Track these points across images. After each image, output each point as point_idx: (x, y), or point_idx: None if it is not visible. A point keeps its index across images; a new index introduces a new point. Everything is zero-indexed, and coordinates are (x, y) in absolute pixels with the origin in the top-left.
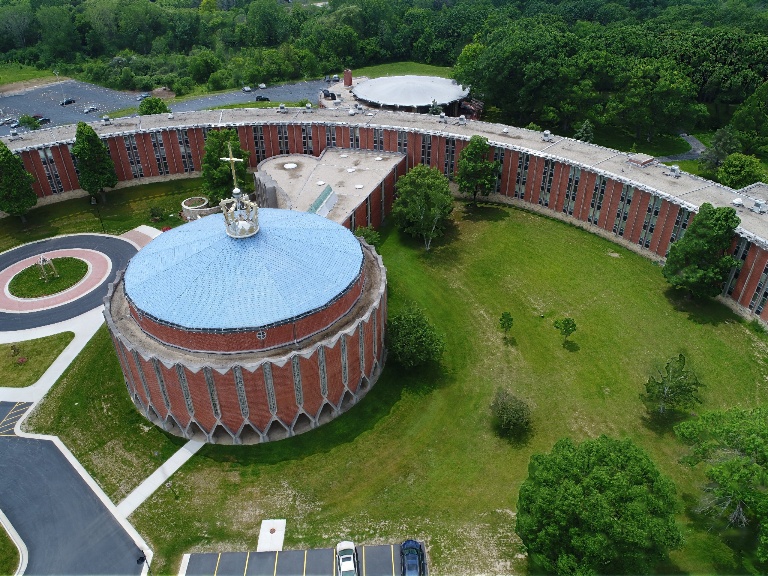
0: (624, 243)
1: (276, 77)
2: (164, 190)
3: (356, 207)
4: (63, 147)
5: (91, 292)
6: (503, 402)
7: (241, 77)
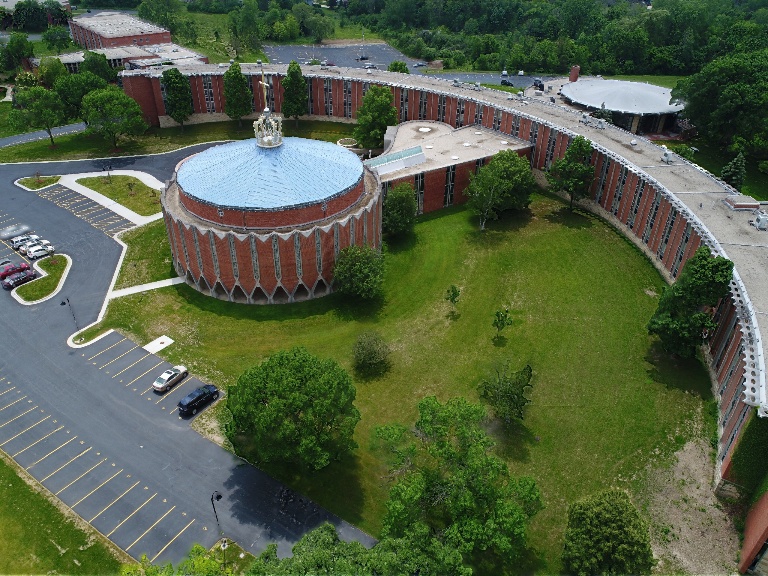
0: None
1: (542, 68)
2: (341, 129)
3: (428, 170)
4: (281, 78)
5: None
6: (361, 337)
7: (506, 62)
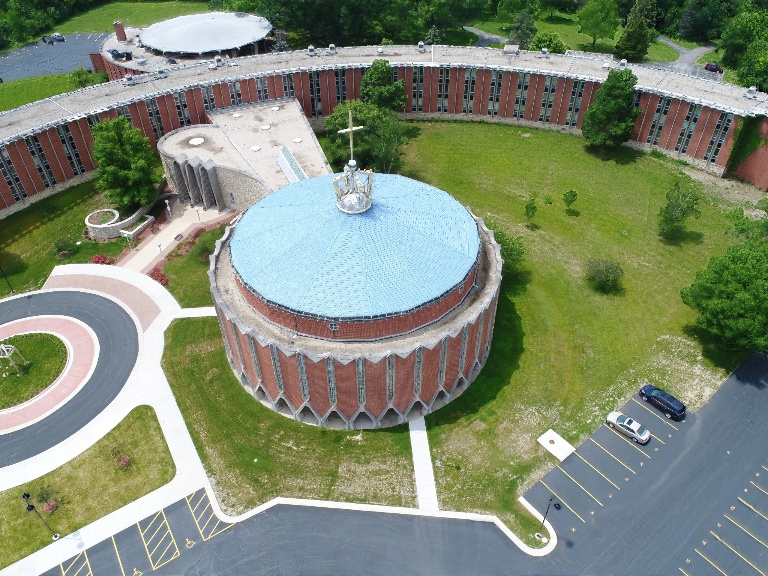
0: (525, 124)
1: None
2: (35, 218)
3: (325, 159)
4: None
5: (100, 359)
6: (605, 265)
7: None
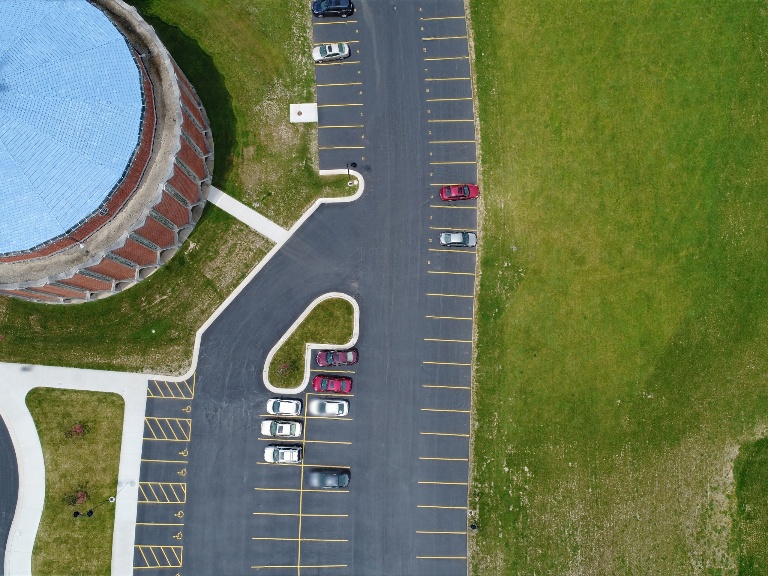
0: None
1: None
2: None
3: None
4: None
5: None
6: None
7: None
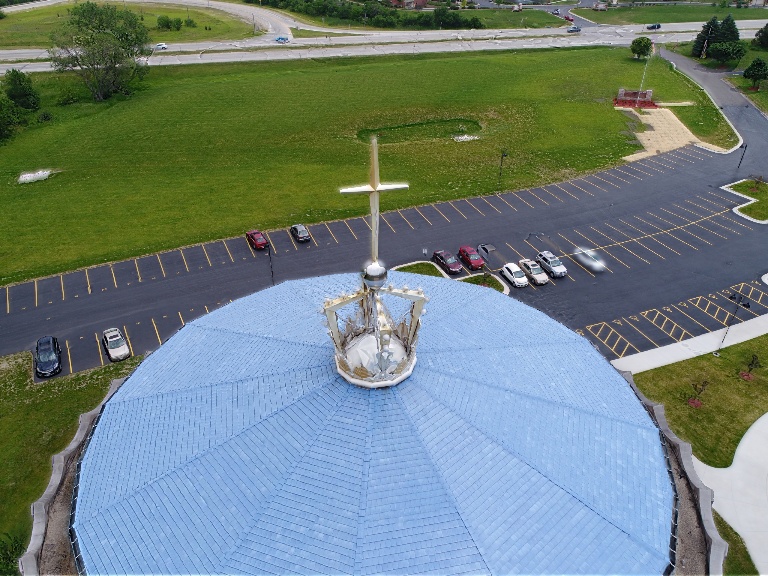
0: None
1: None
2: None
3: None
4: None
5: None
6: None
7: None
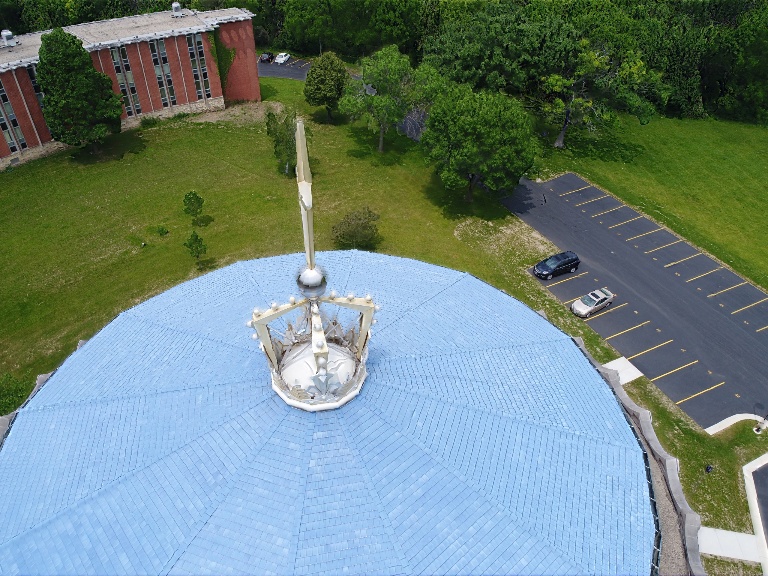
0: None
1: None
2: None
3: None
4: None
5: None
6: (363, 218)
7: None
